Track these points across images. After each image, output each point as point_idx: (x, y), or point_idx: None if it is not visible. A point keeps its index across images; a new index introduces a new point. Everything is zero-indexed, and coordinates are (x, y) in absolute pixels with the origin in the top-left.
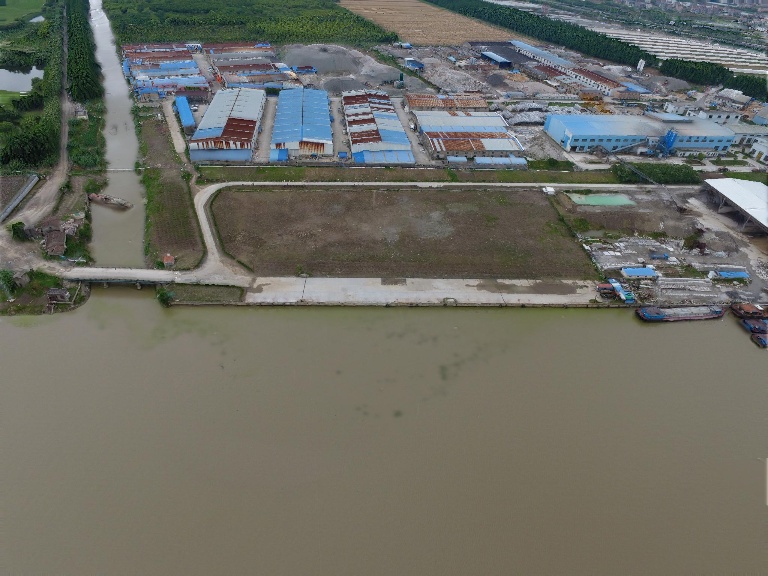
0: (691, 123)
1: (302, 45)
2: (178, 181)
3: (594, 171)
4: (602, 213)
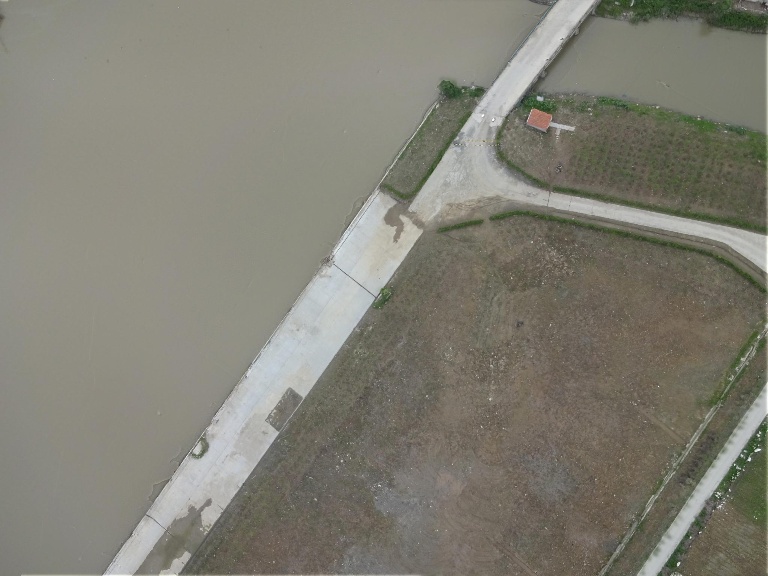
0: None
1: None
2: None
3: None
4: None
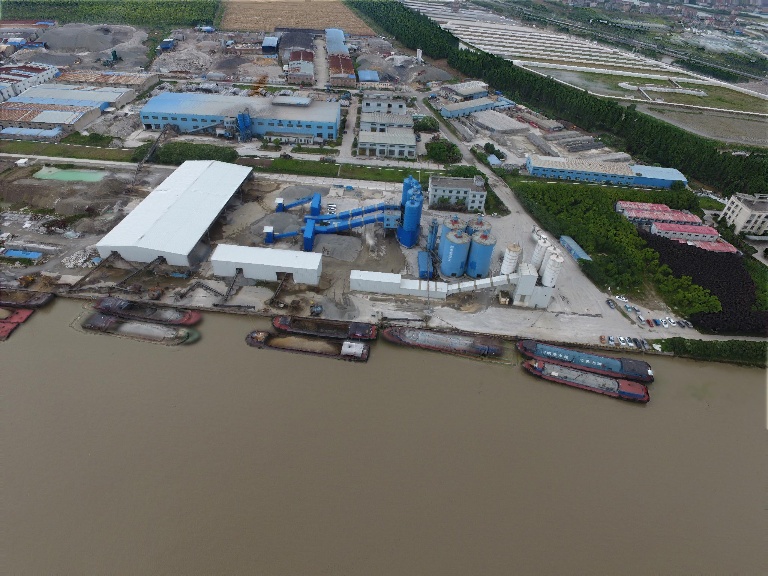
0: (305, 107)
1: (85, 24)
2: None
3: (129, 149)
4: (14, 185)
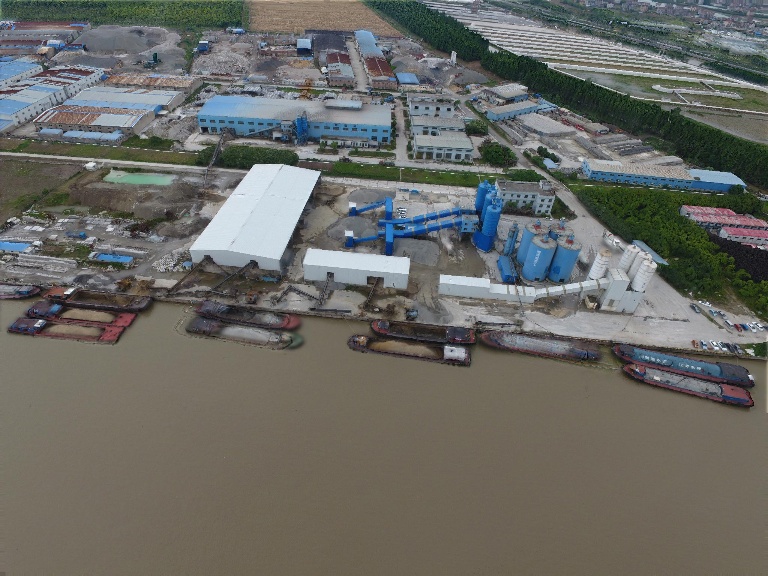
0: (359, 111)
1: (119, 26)
2: None
3: (190, 152)
4: (90, 189)
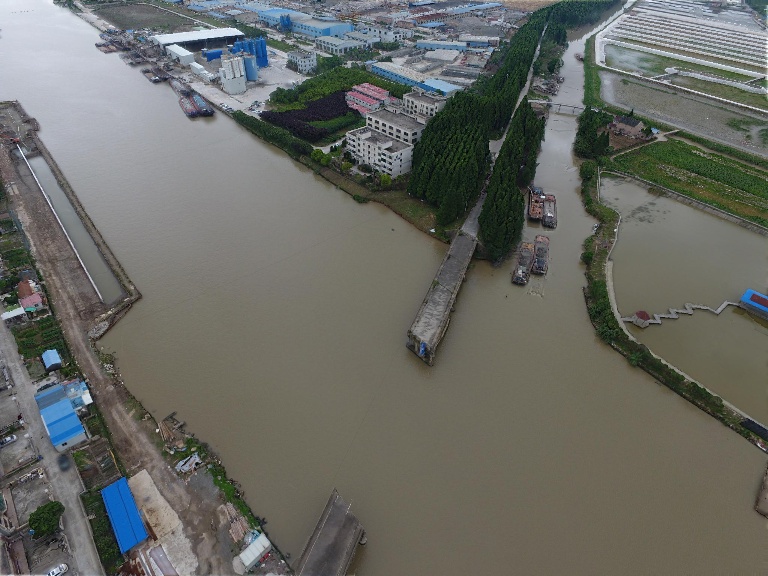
0: None
1: None
2: None
3: None
4: None
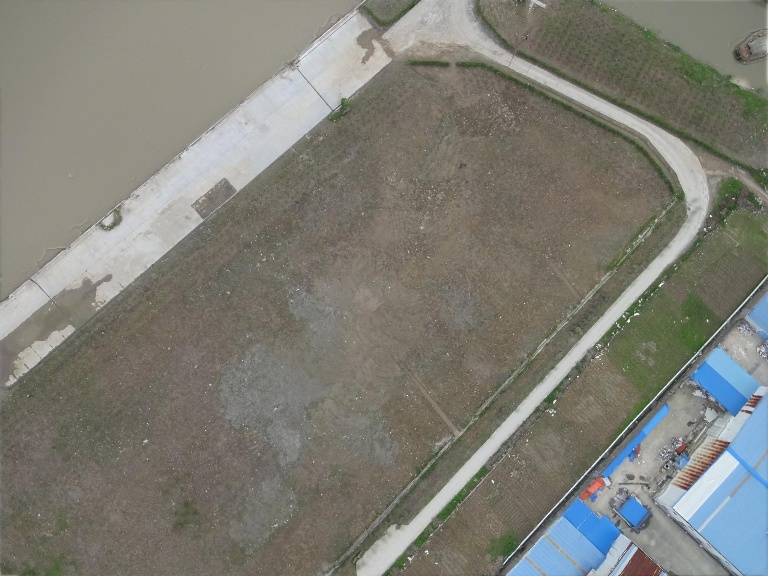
0: None
1: None
2: (765, 158)
3: None
4: None
